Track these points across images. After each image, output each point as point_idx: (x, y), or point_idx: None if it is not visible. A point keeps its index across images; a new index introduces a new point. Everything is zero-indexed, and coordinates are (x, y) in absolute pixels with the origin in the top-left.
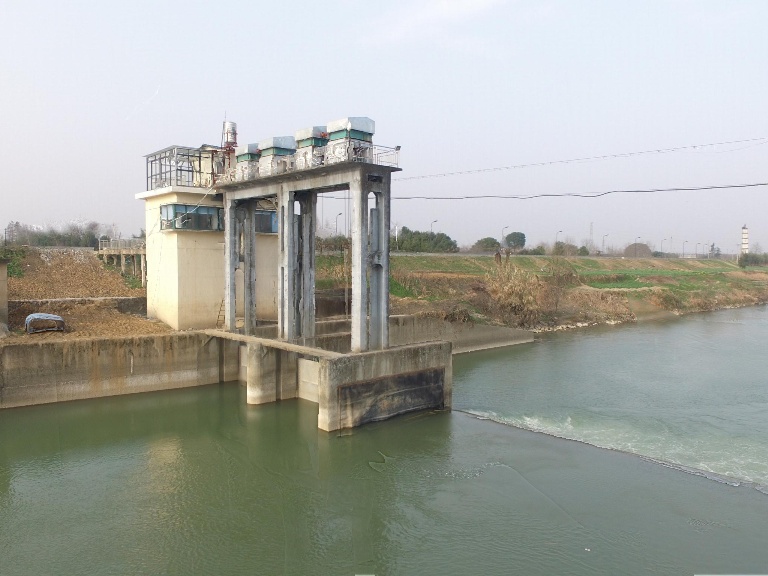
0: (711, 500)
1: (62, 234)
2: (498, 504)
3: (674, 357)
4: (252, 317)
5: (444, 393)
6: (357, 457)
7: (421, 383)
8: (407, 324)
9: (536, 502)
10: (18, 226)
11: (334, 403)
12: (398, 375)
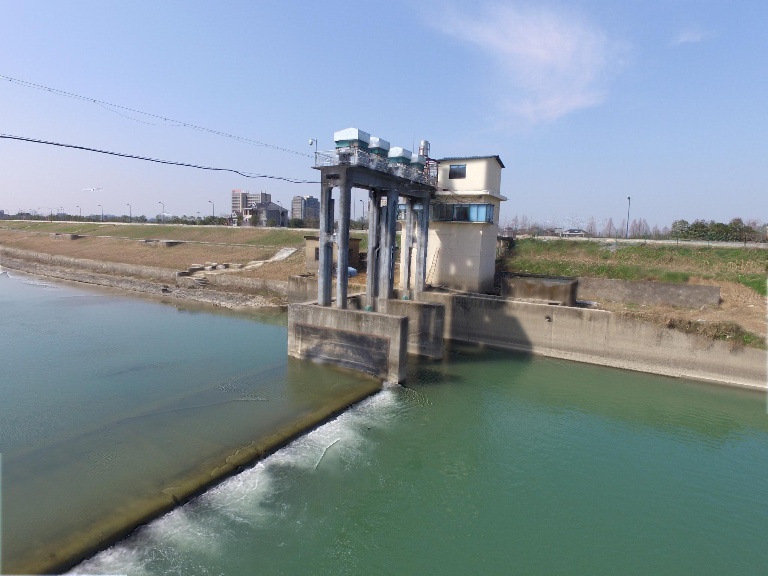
0: (152, 470)
1: (563, 227)
2: (171, 397)
3: None
4: (420, 284)
5: (389, 362)
6: (304, 376)
7: (363, 344)
8: (596, 320)
9: (170, 406)
10: (536, 222)
11: (292, 333)
12: (341, 330)
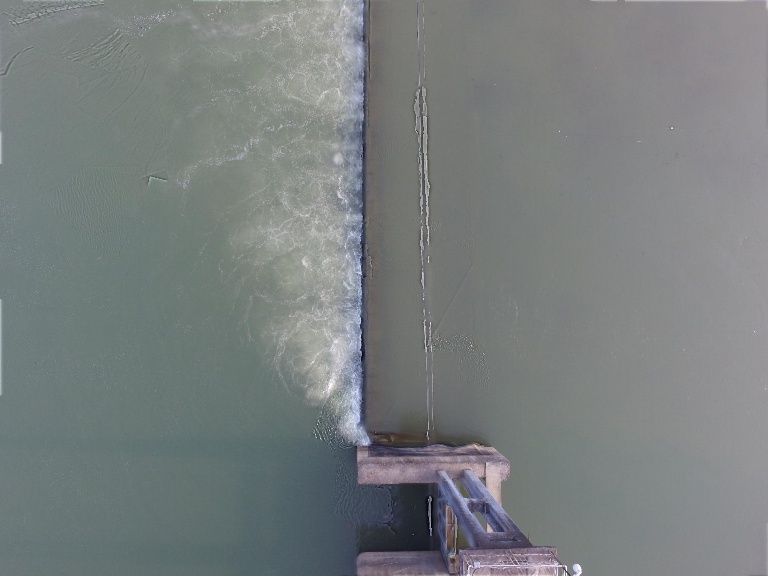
0: (398, 232)
1: None
2: None
3: (2, 396)
4: None
5: None
6: None
7: None
8: None
9: (468, 292)
10: None
11: None
12: None
